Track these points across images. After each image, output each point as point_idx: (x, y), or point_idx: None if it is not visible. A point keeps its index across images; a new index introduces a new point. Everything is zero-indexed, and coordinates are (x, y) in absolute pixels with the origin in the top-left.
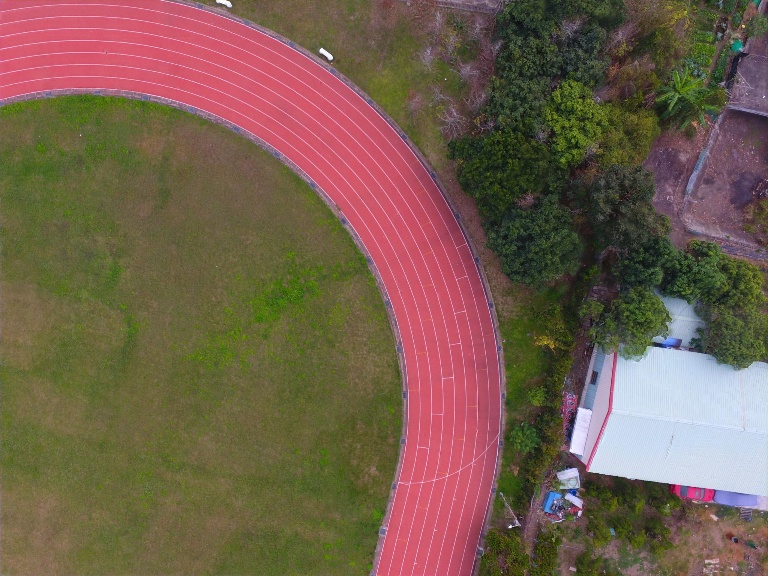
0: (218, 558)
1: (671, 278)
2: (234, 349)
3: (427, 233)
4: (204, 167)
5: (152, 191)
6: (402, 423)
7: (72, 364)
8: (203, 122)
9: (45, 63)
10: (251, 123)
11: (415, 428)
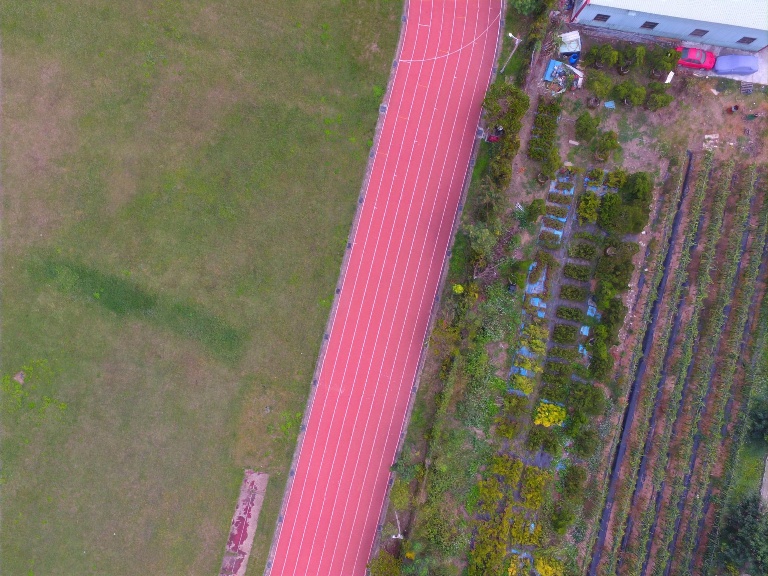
0: (219, 129)
1: None
2: None
3: None
4: None
5: None
6: (404, 0)
7: None
8: None
9: None
10: None
11: (416, 6)
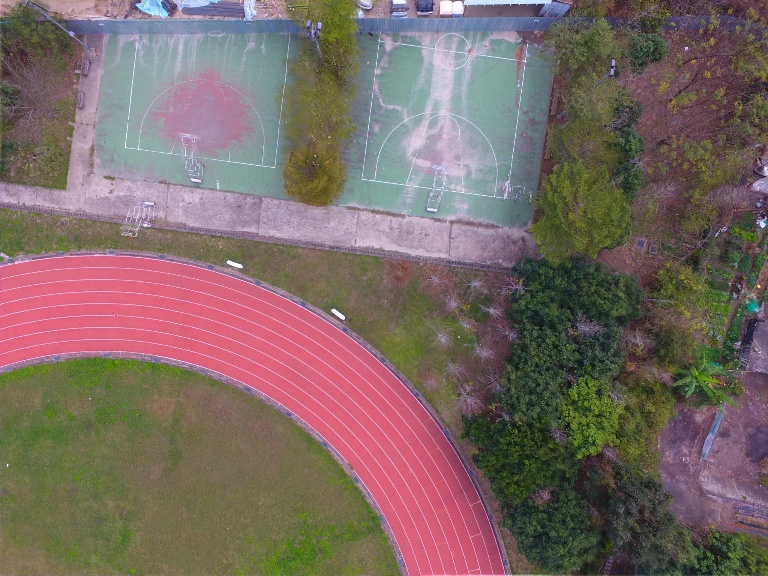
0: None
1: (690, 572)
2: None
3: (440, 491)
4: (215, 428)
5: (162, 453)
6: None
7: None
8: (214, 383)
9: (54, 327)
10: (262, 383)
11: None
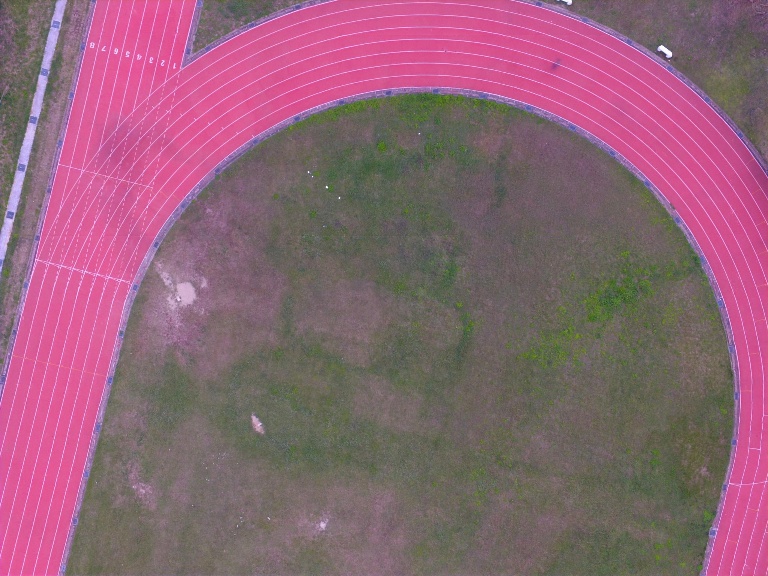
0: (549, 556)
1: None
2: (567, 348)
3: (762, 232)
4: (540, 166)
5: (488, 190)
6: (733, 424)
7: (408, 362)
8: (540, 120)
9: (386, 62)
10: (587, 121)
11: (746, 429)
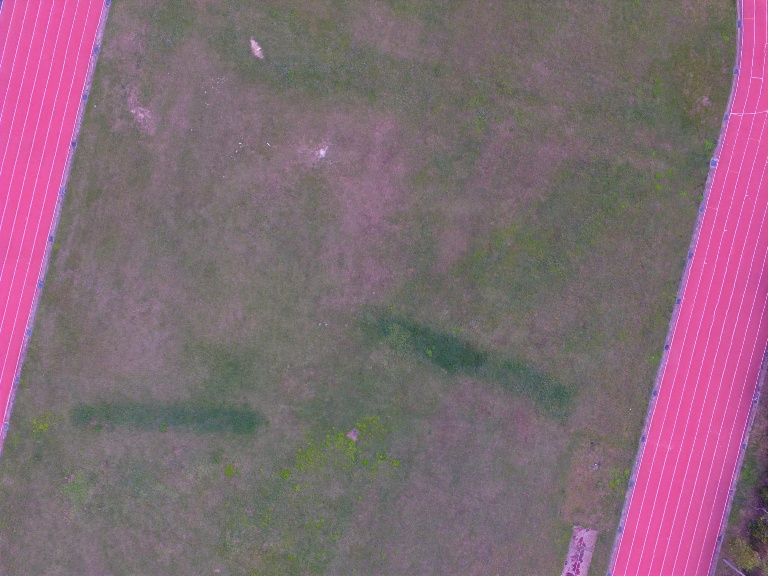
0: (550, 186)
1: None
2: None
3: None
4: None
5: None
6: (736, 52)
7: None
8: None
9: None
10: None
11: (749, 58)
